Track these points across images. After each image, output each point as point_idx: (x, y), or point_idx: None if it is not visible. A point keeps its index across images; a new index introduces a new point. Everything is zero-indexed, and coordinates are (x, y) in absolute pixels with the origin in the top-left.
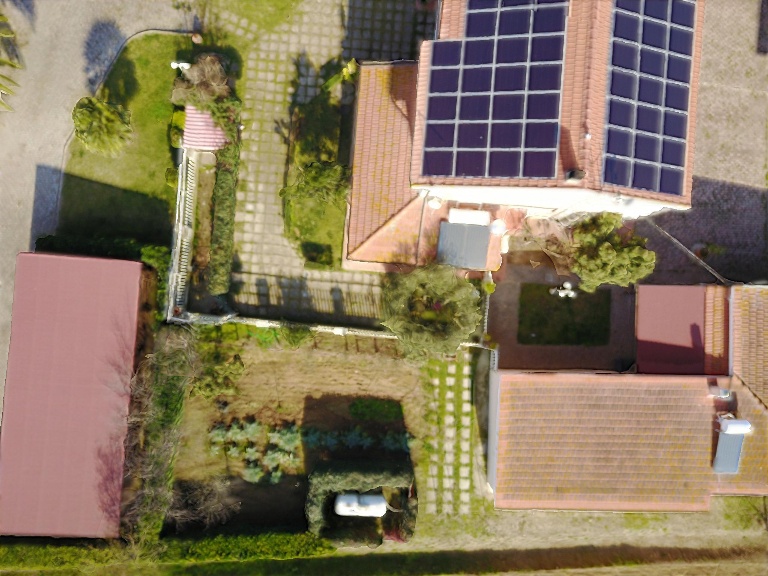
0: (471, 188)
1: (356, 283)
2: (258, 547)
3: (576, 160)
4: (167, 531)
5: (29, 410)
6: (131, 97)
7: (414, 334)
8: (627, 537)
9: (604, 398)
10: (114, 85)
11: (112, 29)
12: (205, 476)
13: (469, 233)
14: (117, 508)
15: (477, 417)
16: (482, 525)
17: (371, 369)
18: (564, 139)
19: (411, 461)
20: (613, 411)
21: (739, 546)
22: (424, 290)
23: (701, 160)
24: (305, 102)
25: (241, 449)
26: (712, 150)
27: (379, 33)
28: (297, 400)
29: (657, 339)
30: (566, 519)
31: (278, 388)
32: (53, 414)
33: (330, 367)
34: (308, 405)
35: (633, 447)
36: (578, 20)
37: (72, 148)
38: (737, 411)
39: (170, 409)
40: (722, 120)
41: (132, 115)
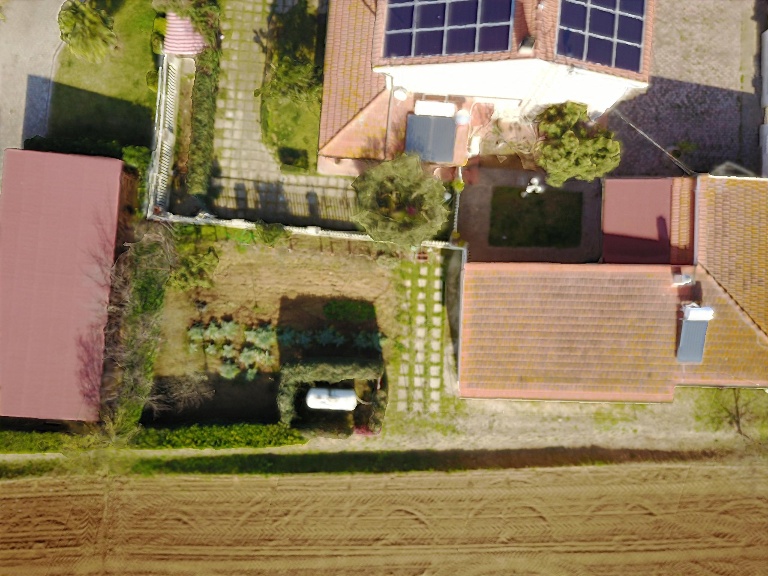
0: (429, 67)
1: (331, 187)
2: (232, 436)
3: (528, 32)
4: (146, 418)
5: (15, 297)
6: (116, 8)
7: (379, 222)
8: (598, 439)
9: (568, 287)
10: None
11: None
12: (185, 372)
13: (435, 126)
14: (97, 393)
15: (448, 318)
16: (452, 423)
17: (345, 271)
18: (517, 12)
19: (383, 360)
20: (577, 301)
21: (711, 449)
22: (392, 185)
23: (674, 64)
24: (283, 12)
25: (219, 347)
26: (686, 54)
27: None
28: (273, 300)
29: (623, 232)
30: (536, 418)
31: (255, 288)
32: (38, 302)
33: (305, 268)
34: (284, 305)
35: (597, 337)
36: None
37: (61, 58)
38: (702, 301)
39: (149, 302)
40: (696, 24)
41: (117, 26)
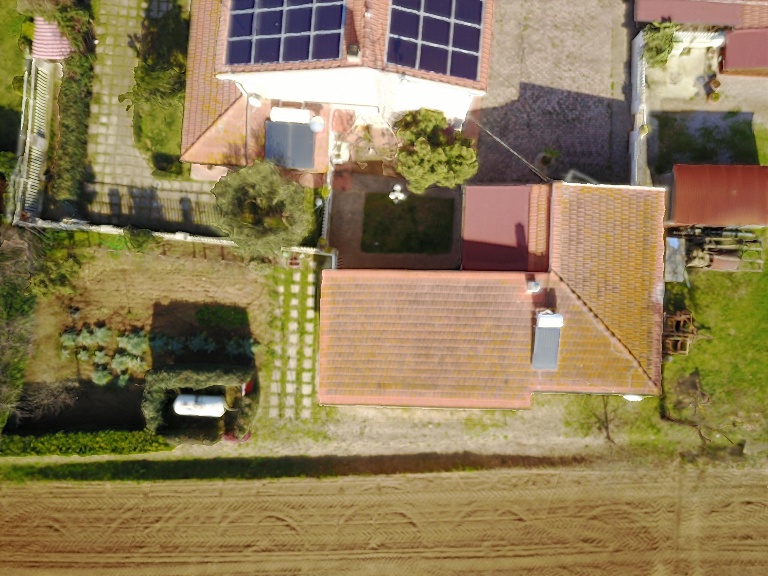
0: (267, 74)
1: (205, 193)
2: (97, 442)
3: (357, 40)
4: (10, 425)
5: None
6: None
7: (234, 229)
8: (470, 444)
9: (424, 294)
10: None
11: None
12: (57, 378)
13: (293, 133)
14: None
15: None
16: (324, 429)
17: (218, 276)
18: (348, 20)
19: (255, 366)
20: (433, 307)
21: (582, 455)
22: (254, 191)
23: (546, 70)
24: (157, 17)
25: (91, 353)
26: (557, 60)
27: None
28: (146, 306)
29: (482, 239)
30: (407, 424)
31: (128, 294)
32: None
33: (178, 274)
34: (157, 311)
35: (453, 343)
36: None
37: None
38: (556, 308)
39: (14, 308)
40: (567, 30)
41: None
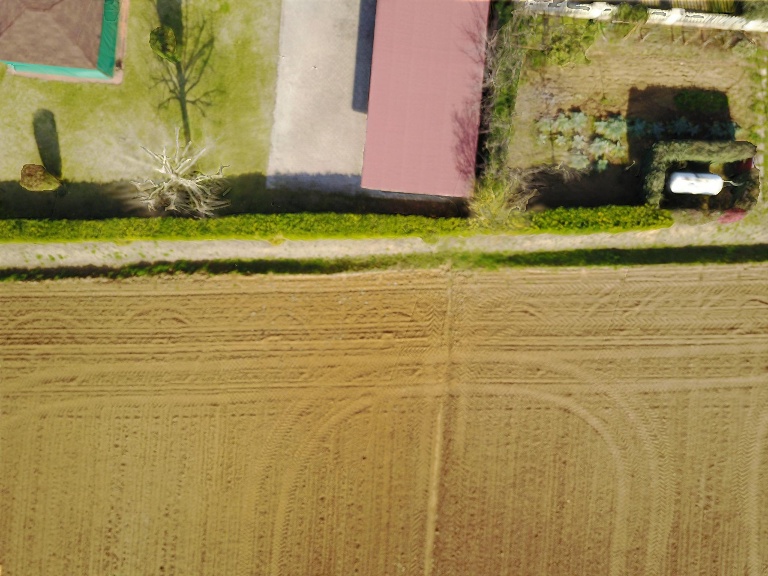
0: None
1: None
2: (599, 217)
3: None
4: None
5: (393, 72)
6: None
7: None
8: None
9: None
10: None
11: None
12: (532, 164)
13: None
14: (473, 169)
15: None
16: None
17: (697, 61)
18: None
19: None
20: None
21: None
22: None
23: None
24: None
25: (567, 139)
26: None
27: None
28: (622, 92)
29: None
30: None
31: (603, 80)
32: (414, 77)
33: (655, 59)
34: (633, 97)
35: None
36: None
37: None
38: None
39: (515, 83)
40: None
41: None
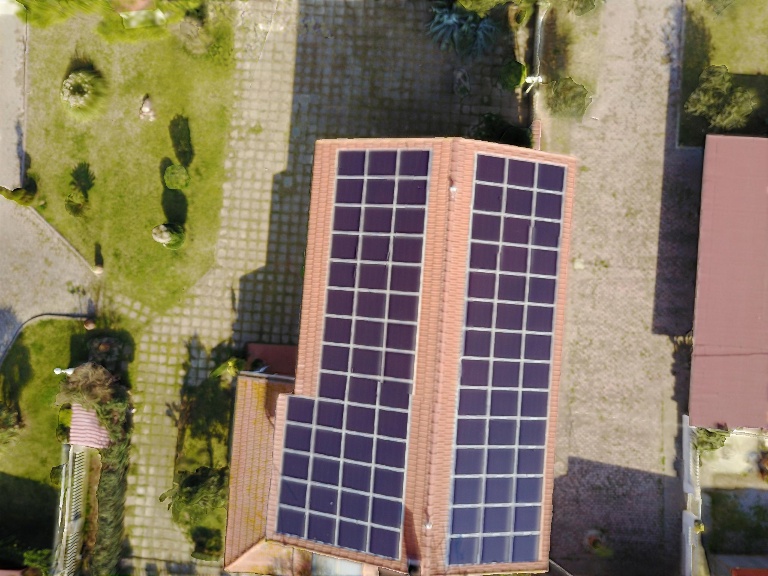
0: None
1: None
2: None
3: (418, 546)
4: None
5: None
6: (25, 383)
7: None
8: None
9: None
10: (9, 370)
11: (8, 314)
12: None
13: None
14: None
15: None
16: None
17: None
18: (408, 521)
19: None
20: None
21: None
22: None
23: (595, 444)
24: (196, 384)
25: None
26: (606, 434)
27: (269, 316)
28: None
29: None
30: None
31: None
32: None
33: None
34: None
35: None
36: (421, 400)
37: None
38: None
39: None
40: (616, 403)
41: (26, 401)
